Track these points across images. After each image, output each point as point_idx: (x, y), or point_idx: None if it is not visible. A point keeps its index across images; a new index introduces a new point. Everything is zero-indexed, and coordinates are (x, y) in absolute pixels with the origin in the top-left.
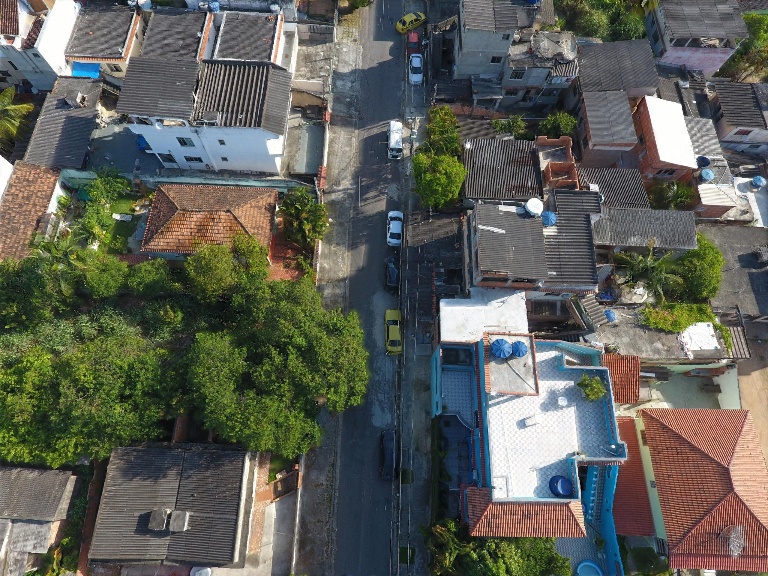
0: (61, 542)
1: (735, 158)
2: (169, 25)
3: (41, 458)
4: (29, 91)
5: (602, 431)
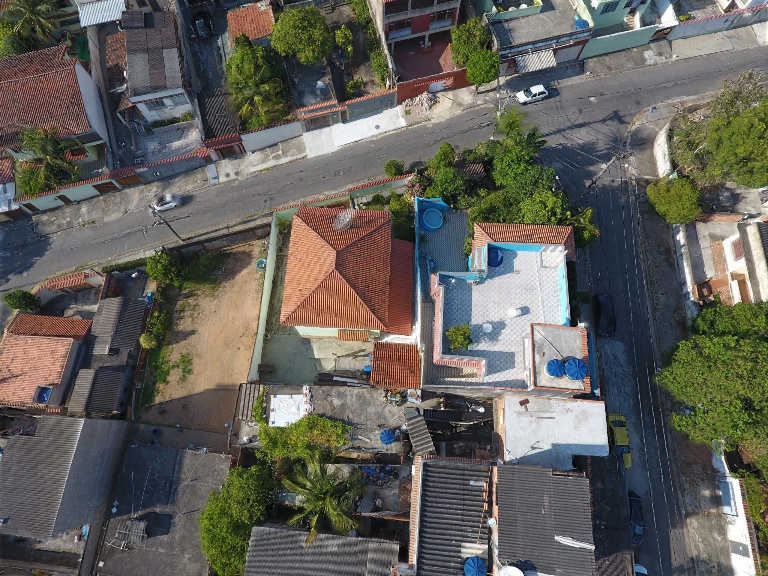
0: None
1: None
2: None
3: None
4: None
5: (447, 302)
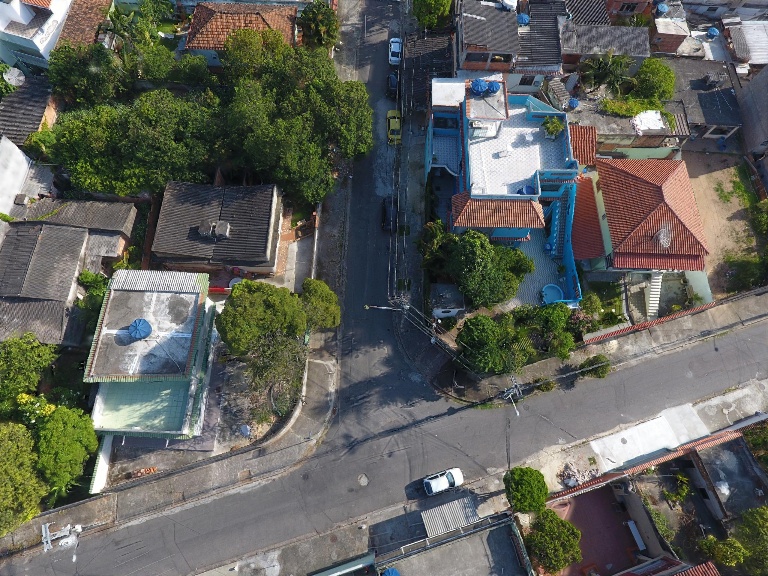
0: (128, 248)
1: (695, 19)
2: None
3: (110, 189)
4: None
5: (561, 161)
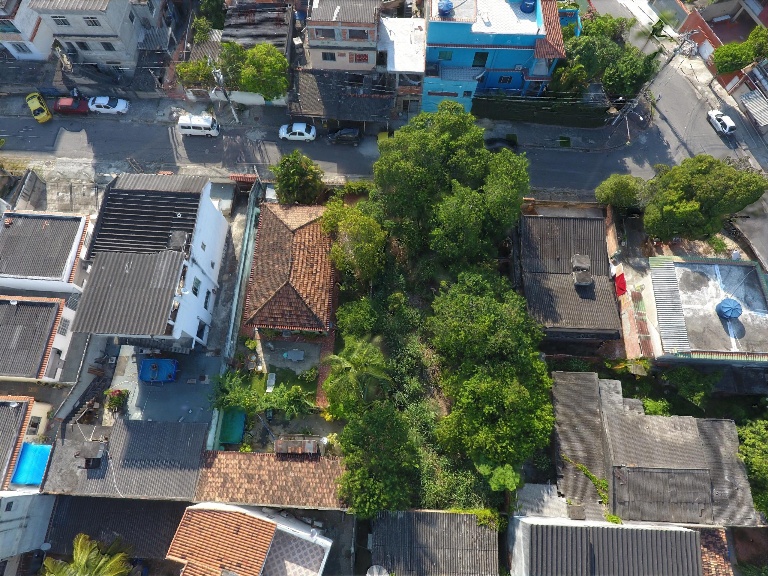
0: None
1: None
2: None
3: None
4: (39, 566)
5: None
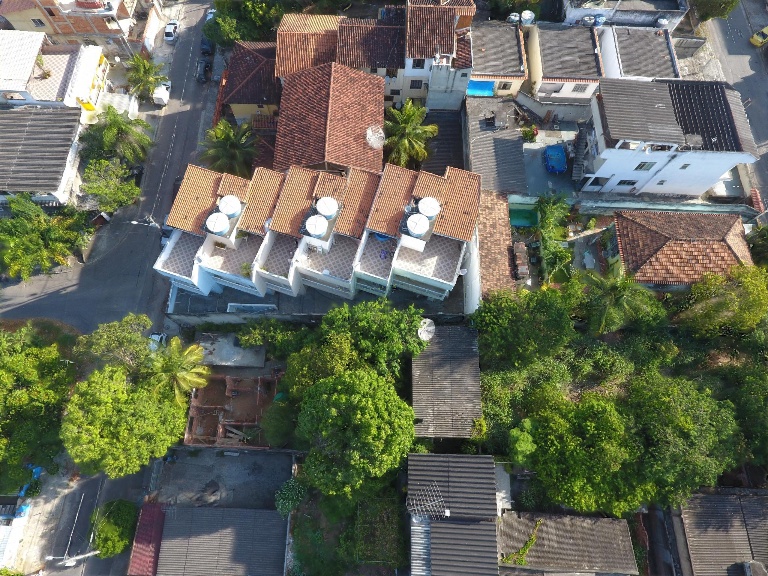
0: None
1: None
2: (559, 41)
3: (603, 506)
4: None
5: None
